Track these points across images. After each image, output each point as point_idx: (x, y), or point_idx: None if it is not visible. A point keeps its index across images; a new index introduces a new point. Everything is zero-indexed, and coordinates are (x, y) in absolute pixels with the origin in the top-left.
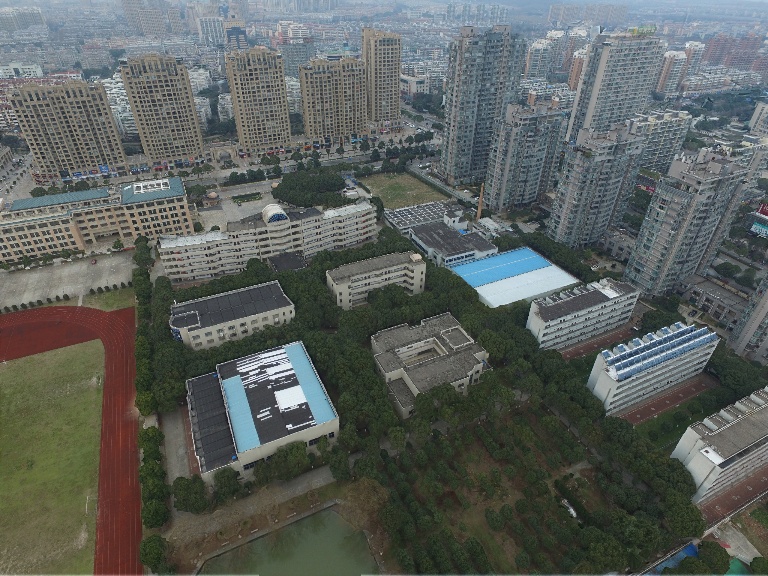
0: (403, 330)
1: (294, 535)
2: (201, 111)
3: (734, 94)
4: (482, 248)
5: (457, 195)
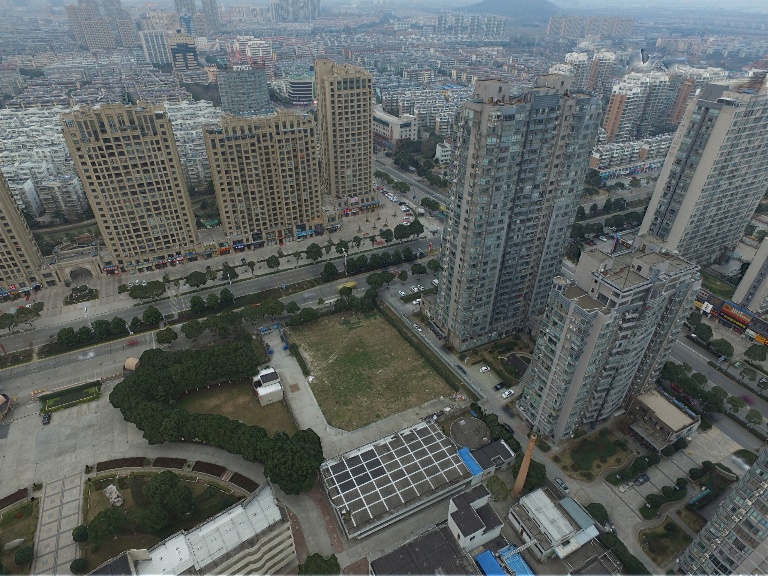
0: None
1: None
2: (69, 184)
3: None
4: None
5: (468, 384)
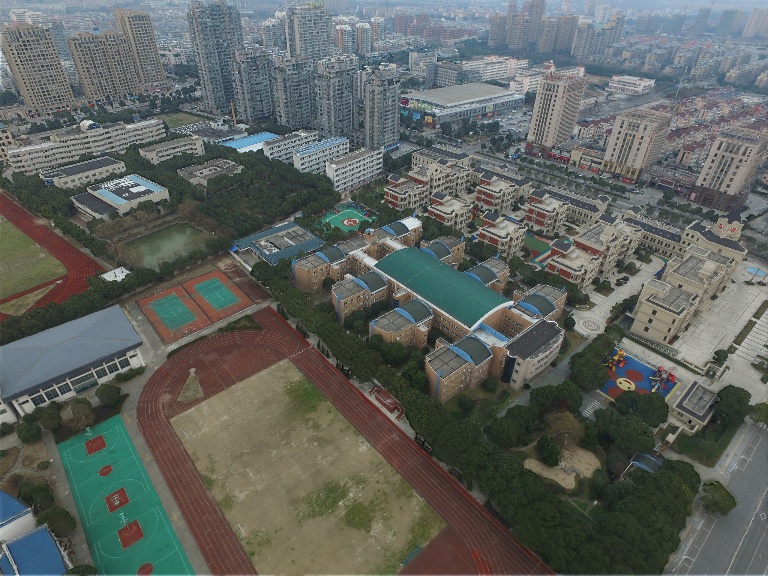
0: (195, 167)
1: (159, 242)
2: None
3: (407, 51)
4: (238, 134)
5: None
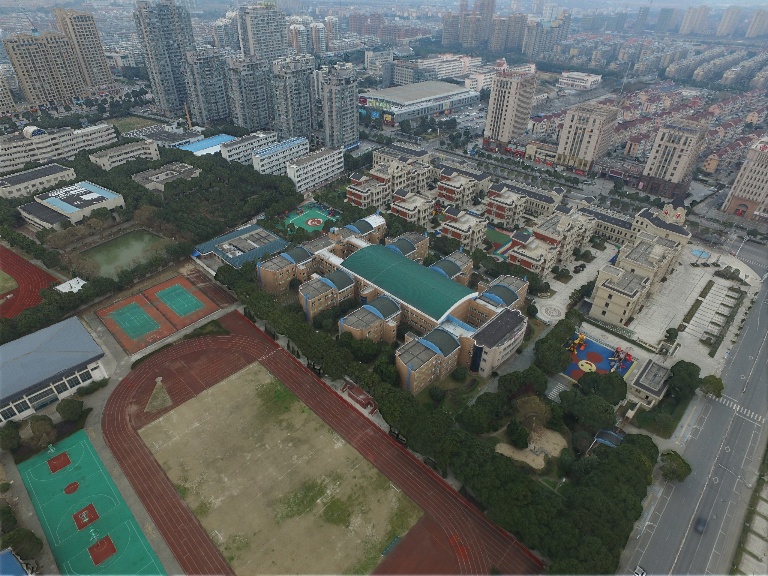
0: (150, 171)
1: (116, 250)
2: None
3: None
4: (193, 137)
5: None
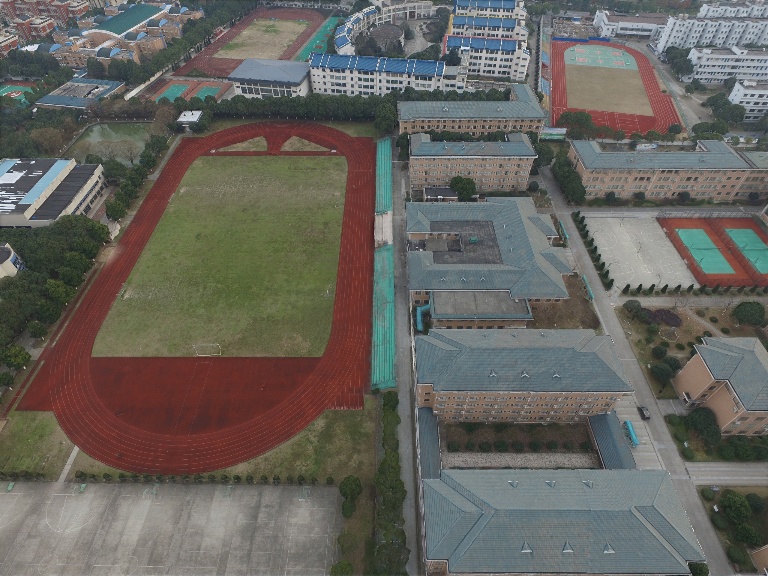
0: None
1: None
2: None
3: None
4: None
5: None
